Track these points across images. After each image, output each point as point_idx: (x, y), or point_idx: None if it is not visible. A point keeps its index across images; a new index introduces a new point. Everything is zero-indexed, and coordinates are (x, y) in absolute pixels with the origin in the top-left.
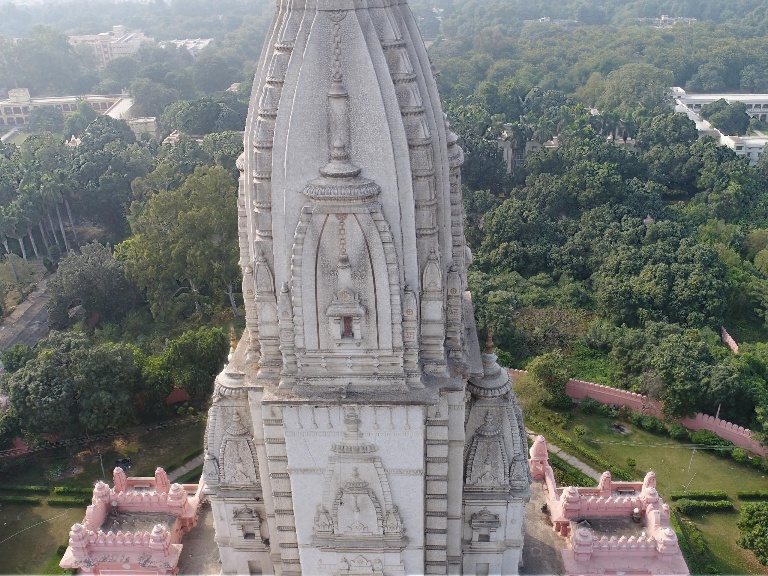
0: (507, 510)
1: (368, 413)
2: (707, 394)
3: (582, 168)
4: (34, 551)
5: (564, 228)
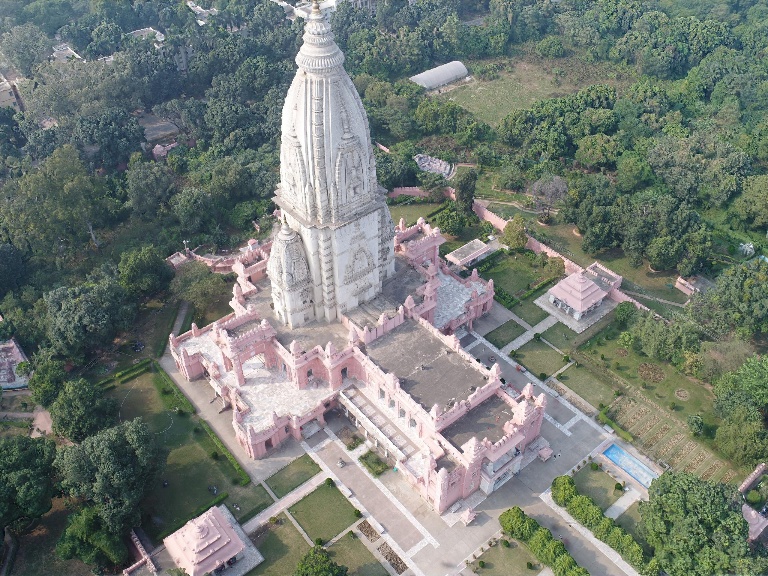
0: (390, 244)
1: (362, 220)
2: (396, 177)
3: (248, 65)
4: (145, 401)
5: (257, 110)
